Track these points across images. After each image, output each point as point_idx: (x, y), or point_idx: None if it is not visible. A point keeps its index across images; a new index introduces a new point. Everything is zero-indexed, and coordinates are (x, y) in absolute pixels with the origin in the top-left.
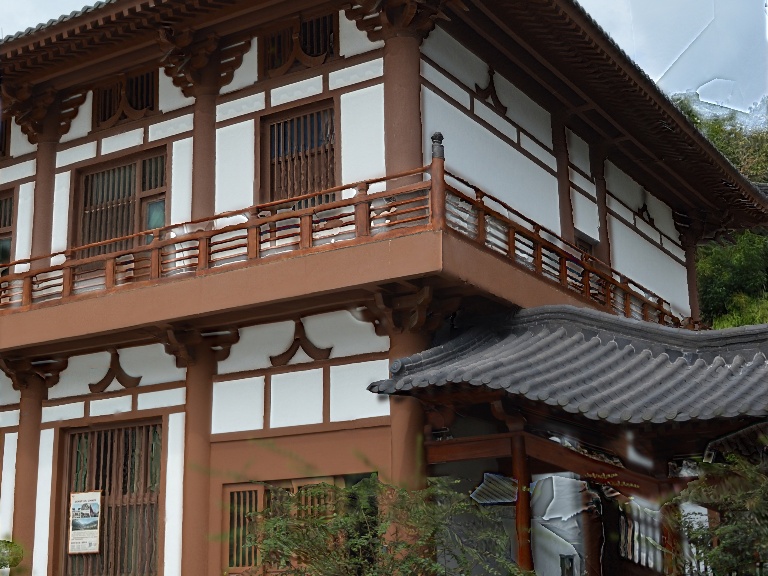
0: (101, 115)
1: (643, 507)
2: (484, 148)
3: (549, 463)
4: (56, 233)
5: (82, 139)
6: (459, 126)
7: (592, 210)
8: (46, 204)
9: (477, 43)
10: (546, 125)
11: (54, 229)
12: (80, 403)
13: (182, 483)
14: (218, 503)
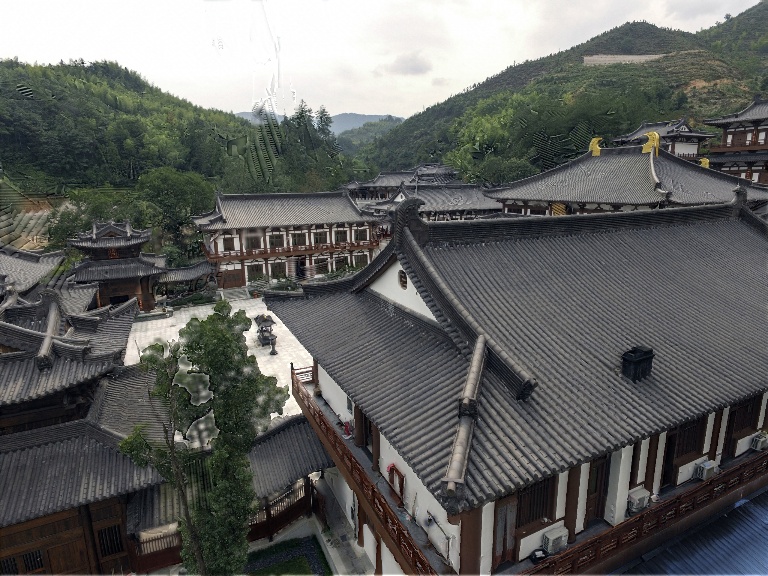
0: None
1: None
2: None
3: None
4: None
5: None
6: None
7: None
8: None
9: None
10: None
11: None
12: None
13: None
14: None
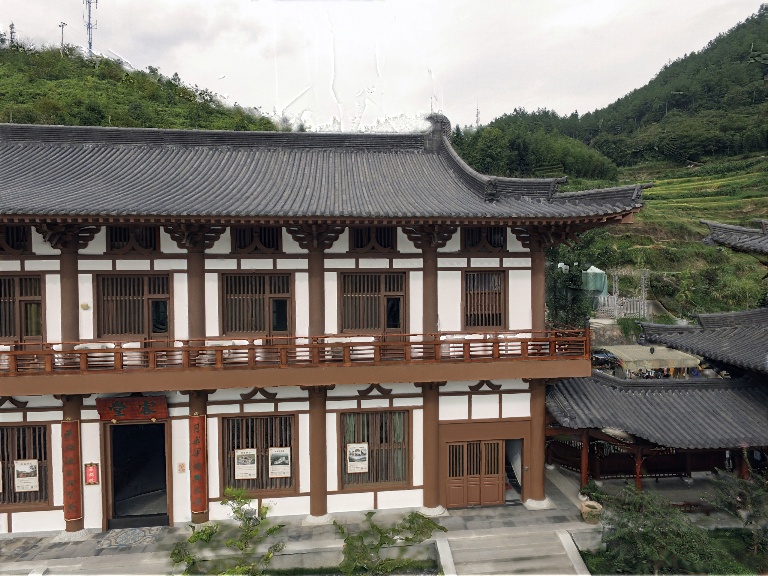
0: (354, 243)
1: (630, 454)
2: None
3: (598, 439)
4: (327, 306)
5: (344, 255)
6: None
7: None
8: (321, 289)
9: None
10: None
11: (326, 304)
12: (354, 401)
13: (423, 442)
14: (444, 451)
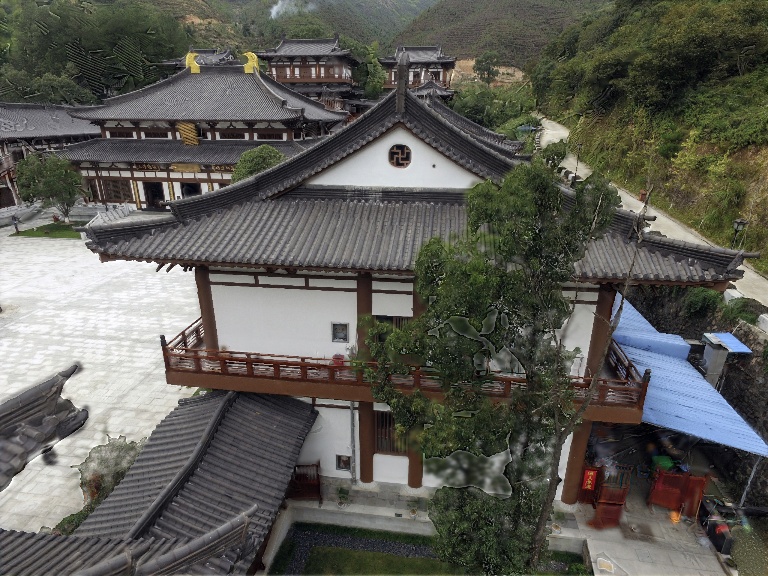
0: None
1: None
2: (268, 299)
3: None
4: None
5: None
6: (245, 294)
7: (405, 300)
8: None
9: None
10: None
11: None
12: None
13: None
14: None
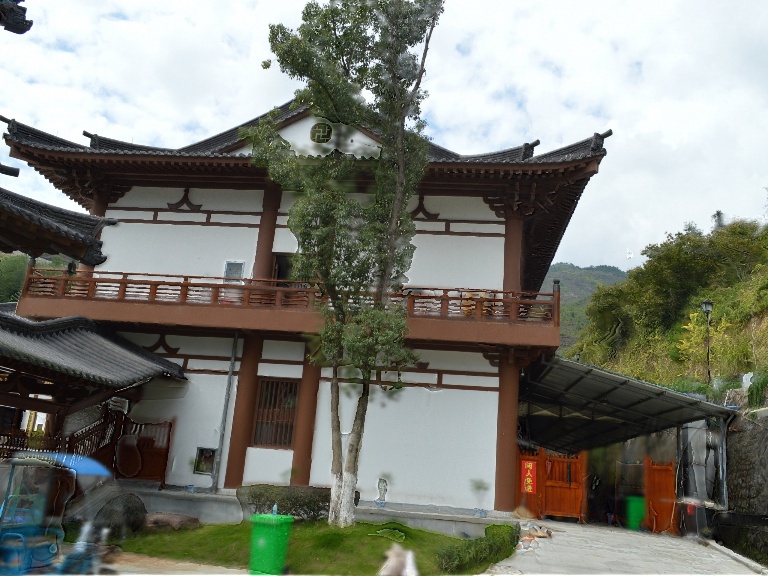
0: None
1: None
2: (162, 235)
3: None
4: None
5: None
6: (139, 231)
7: None
8: None
9: (162, 184)
10: (255, 199)
11: None
12: None
13: None
14: None
